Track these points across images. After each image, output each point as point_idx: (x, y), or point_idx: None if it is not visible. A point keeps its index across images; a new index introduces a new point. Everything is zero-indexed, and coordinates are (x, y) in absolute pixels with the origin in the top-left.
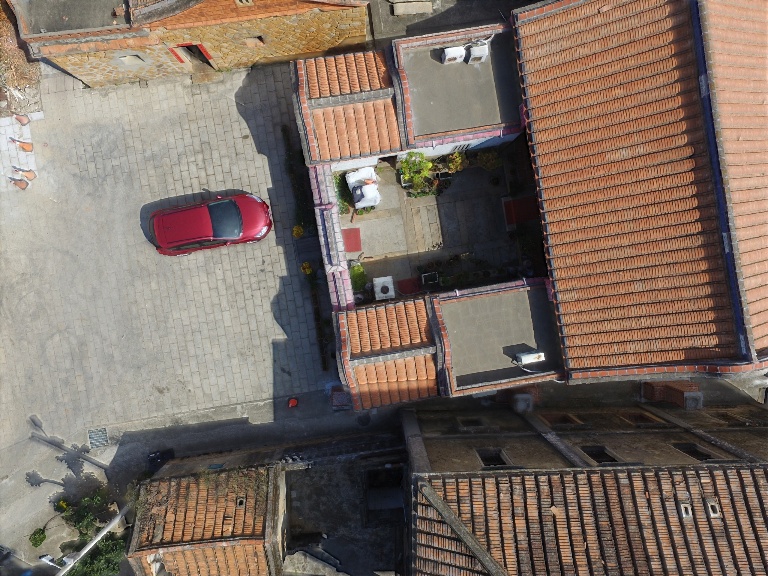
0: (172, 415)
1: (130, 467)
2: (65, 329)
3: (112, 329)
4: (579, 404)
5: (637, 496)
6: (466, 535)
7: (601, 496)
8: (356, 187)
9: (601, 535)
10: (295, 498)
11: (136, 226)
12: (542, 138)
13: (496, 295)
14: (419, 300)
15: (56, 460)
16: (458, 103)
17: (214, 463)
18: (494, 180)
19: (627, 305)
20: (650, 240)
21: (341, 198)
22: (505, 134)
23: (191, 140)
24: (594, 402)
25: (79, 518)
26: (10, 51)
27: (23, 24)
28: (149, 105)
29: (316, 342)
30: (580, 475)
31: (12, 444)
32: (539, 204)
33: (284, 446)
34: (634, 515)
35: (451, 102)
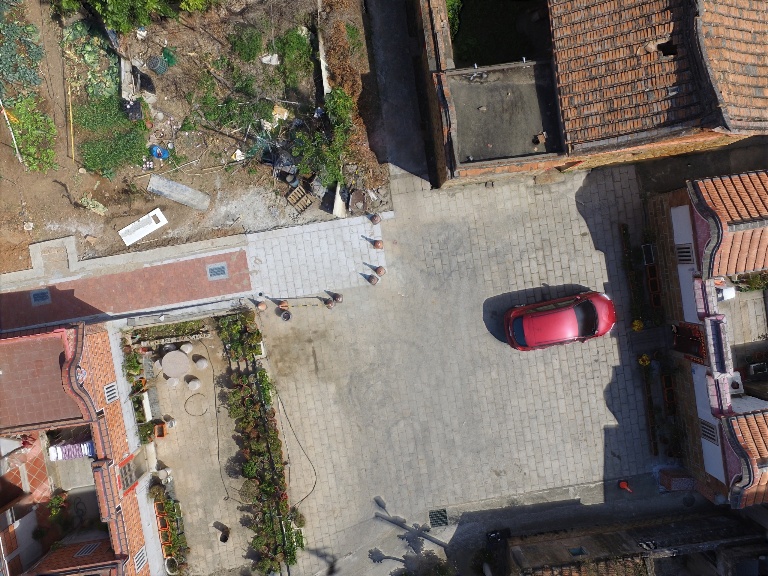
0: (508, 496)
1: (468, 545)
2: (409, 416)
3: (454, 416)
4: None
5: None
6: None
7: None
8: (717, 290)
9: None
10: None
11: (479, 319)
12: None
13: None
14: None
15: (398, 538)
16: None
17: (569, 547)
18: None
19: None
20: None
21: None
22: None
23: (532, 237)
24: None
25: None
26: (367, 155)
27: None
28: (494, 204)
29: (645, 428)
30: None
31: (356, 523)
32: None
33: (620, 527)
34: None
35: None
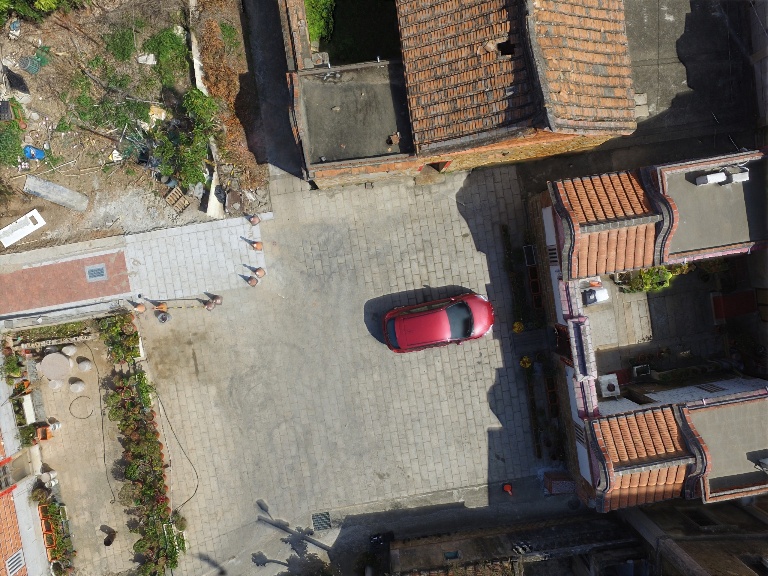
0: (392, 500)
1: (351, 549)
2: (291, 418)
3: (336, 418)
4: None
5: None
6: None
7: None
8: (589, 292)
9: None
10: None
11: (360, 321)
12: None
13: (742, 404)
14: (667, 408)
15: (281, 542)
16: (710, 222)
17: (445, 551)
18: (705, 276)
19: None
20: None
21: None
22: (752, 250)
23: (413, 239)
24: None
25: None
26: (244, 155)
27: (307, 154)
28: (374, 205)
29: (529, 430)
30: None
31: (239, 527)
32: None
33: (502, 531)
34: None
35: (703, 221)
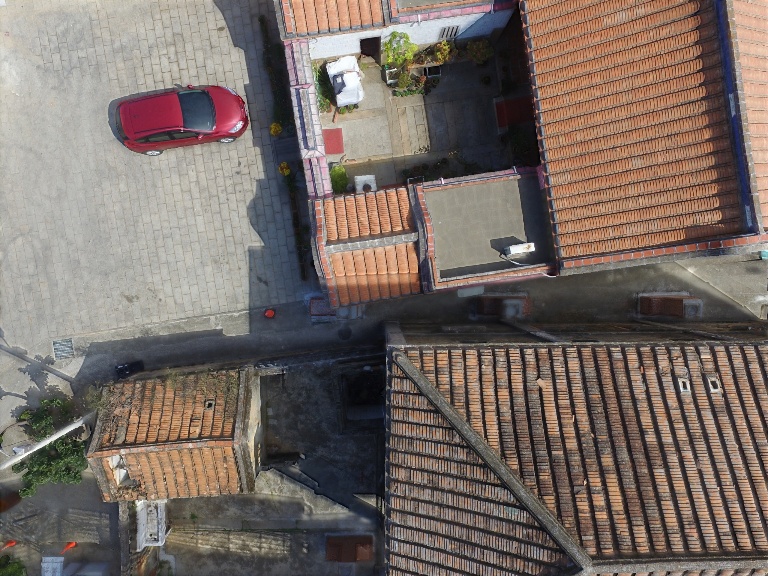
0: (142, 326)
1: (97, 380)
2: (28, 232)
3: (78, 233)
4: (572, 319)
5: (631, 370)
6: (443, 404)
7: (592, 370)
8: (337, 75)
9: (591, 408)
10: (271, 416)
11: (104, 123)
12: (535, 5)
13: (484, 183)
14: (401, 188)
15: (19, 372)
16: None
17: (184, 371)
18: (485, 78)
19: (624, 184)
20: (650, 111)
21: (322, 94)
22: (496, 10)
23: (163, 31)
24: (588, 317)
25: (37, 419)
26: None
27: None
28: None
29: (295, 250)
30: (569, 349)
31: None
32: (531, 80)
33: (259, 358)
34: (627, 389)
35: None
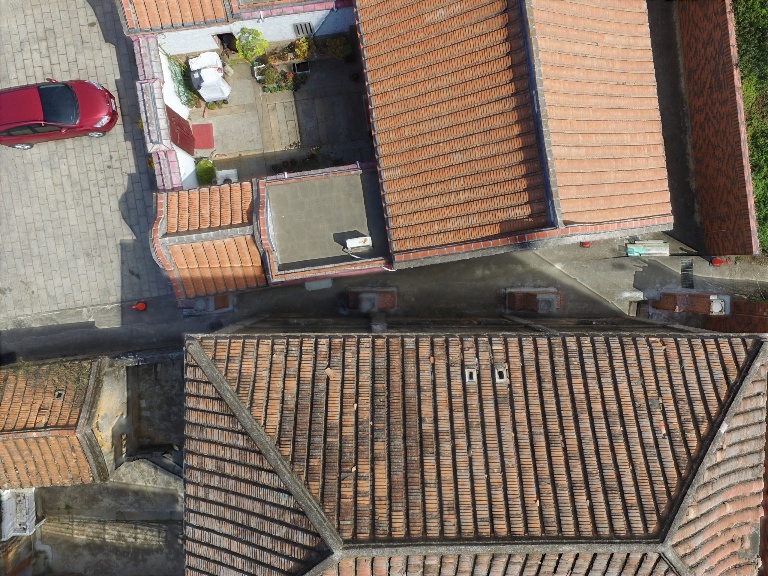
0: (14, 317)
1: None
2: None
3: None
4: (441, 314)
5: (421, 360)
6: (225, 392)
7: (382, 359)
8: None
9: (374, 397)
10: (145, 408)
11: None
12: (366, 3)
13: (326, 178)
14: (246, 182)
15: None
16: None
17: None
18: (354, 75)
19: (447, 179)
20: (468, 107)
21: (190, 89)
22: (339, 7)
23: (34, 26)
24: (457, 312)
25: None
26: None
27: None
28: None
29: None
30: (363, 339)
31: None
32: None
33: (128, 350)
34: (414, 379)
35: None
